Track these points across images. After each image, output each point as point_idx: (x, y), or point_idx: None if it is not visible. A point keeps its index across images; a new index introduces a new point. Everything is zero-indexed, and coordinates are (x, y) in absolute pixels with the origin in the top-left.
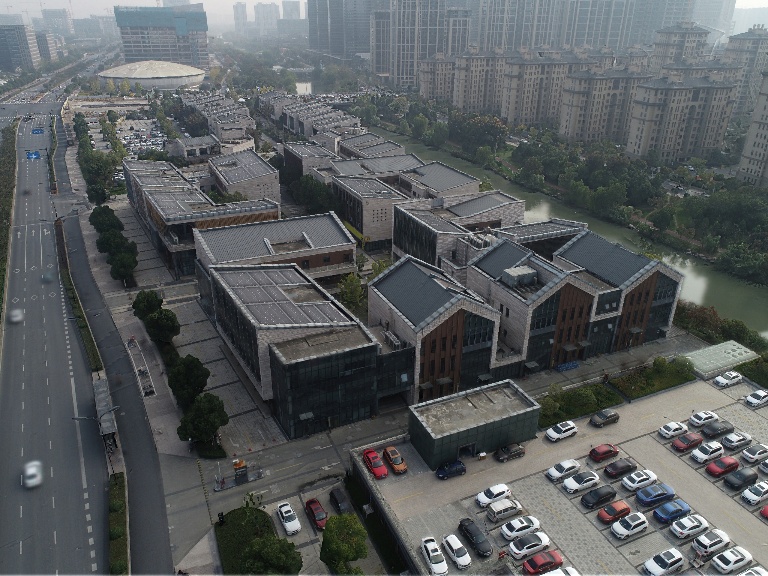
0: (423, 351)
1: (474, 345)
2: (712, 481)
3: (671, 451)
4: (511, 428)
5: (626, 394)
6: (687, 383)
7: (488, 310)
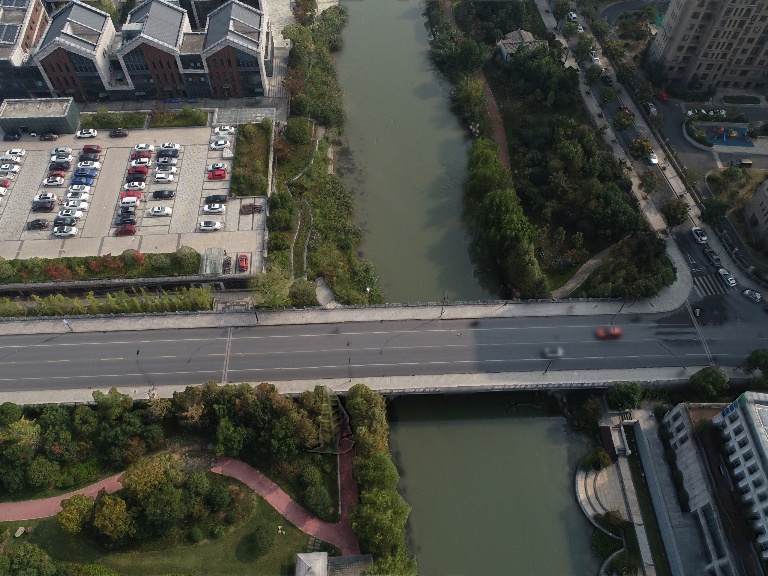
0: (46, 70)
1: (85, 72)
2: (125, 176)
3: (129, 158)
4: (50, 124)
5: (149, 123)
6: (197, 126)
7: (82, 51)
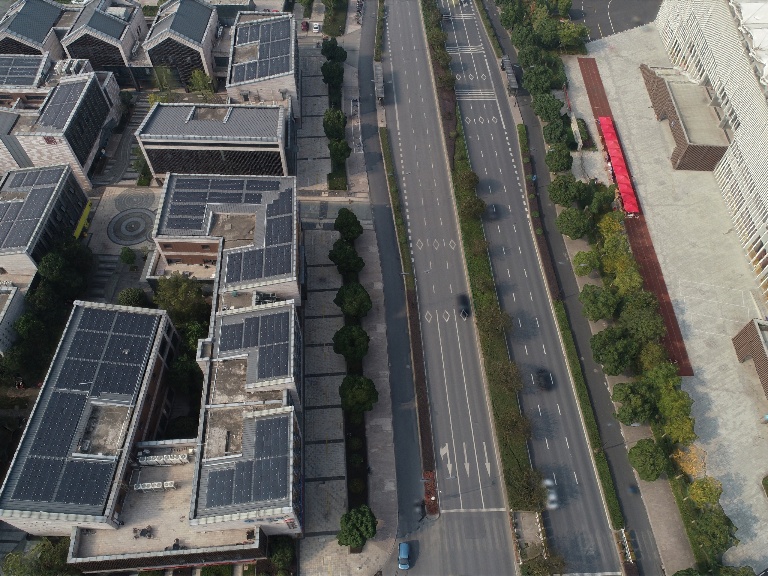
0: None
1: None
2: None
3: None
4: None
5: None
6: None
7: None
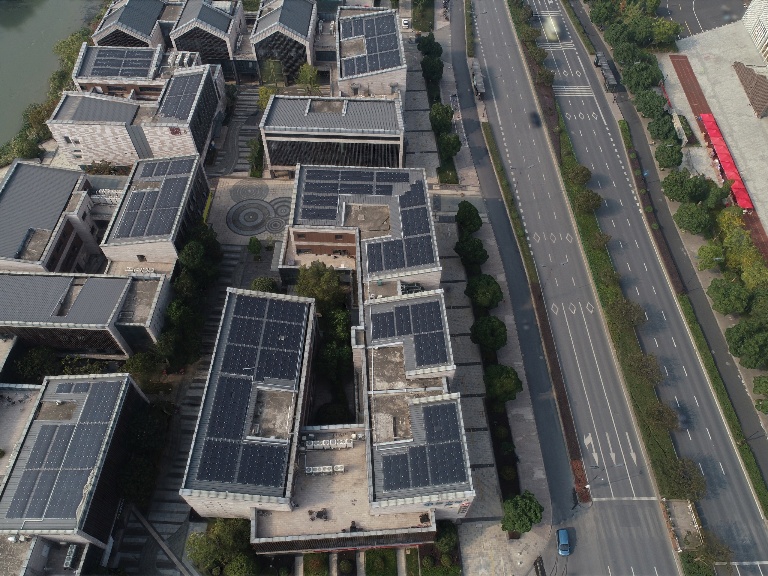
0: None
1: None
2: None
3: None
4: None
5: None
6: None
7: None
